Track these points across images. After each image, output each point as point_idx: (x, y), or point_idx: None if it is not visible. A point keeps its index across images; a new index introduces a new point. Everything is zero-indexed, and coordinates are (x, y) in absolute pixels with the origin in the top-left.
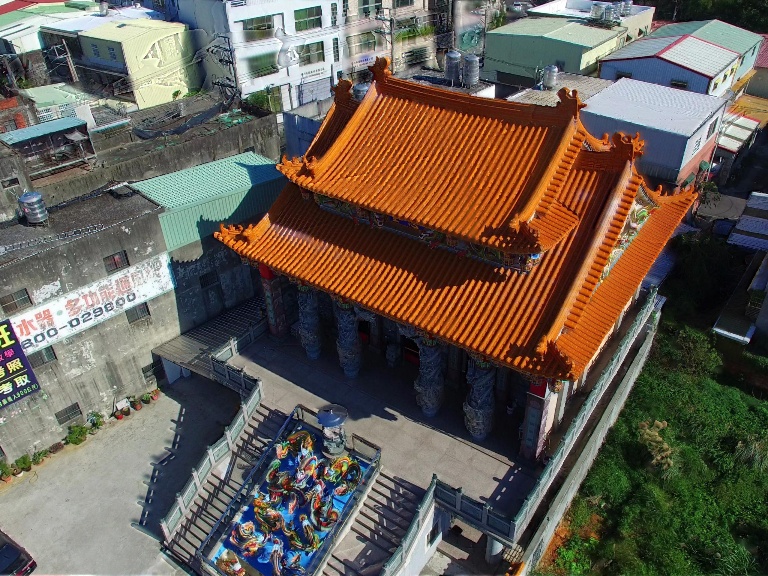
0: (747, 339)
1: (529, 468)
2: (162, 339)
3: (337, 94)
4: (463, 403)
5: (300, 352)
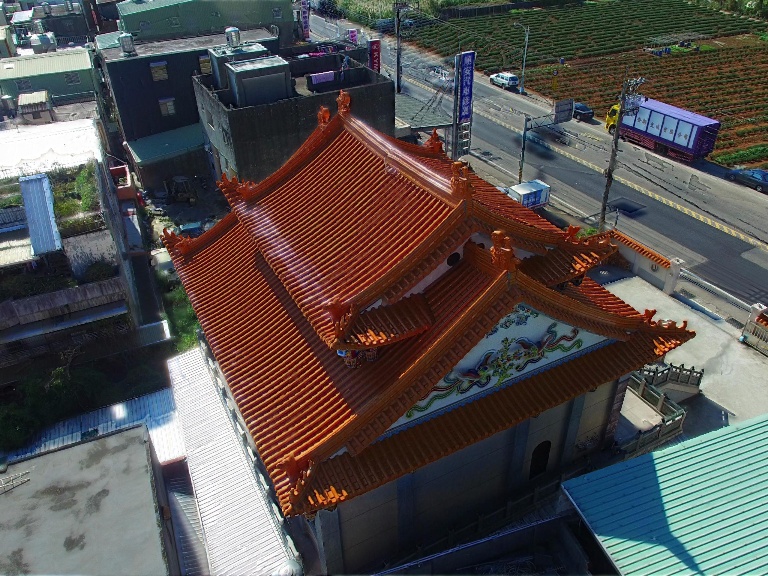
0: (165, 321)
1: None
2: None
3: None
4: None
5: None
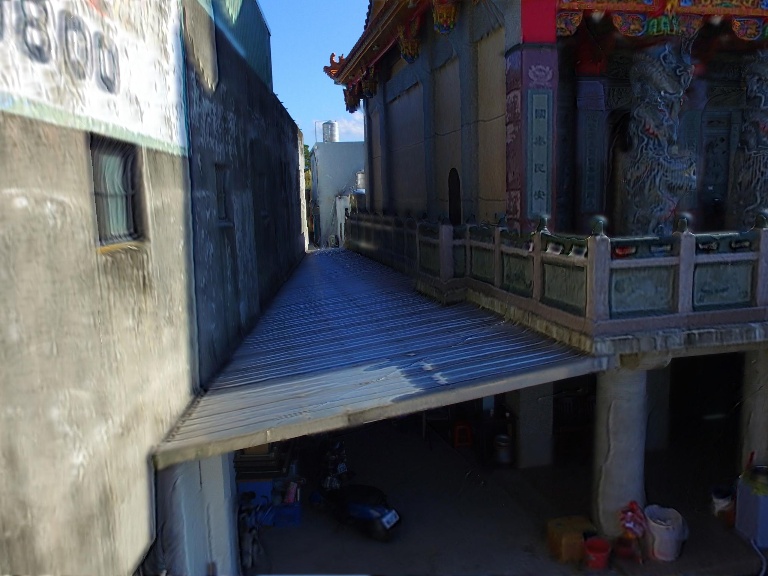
0: None
1: None
2: (168, 400)
3: None
4: None
5: None
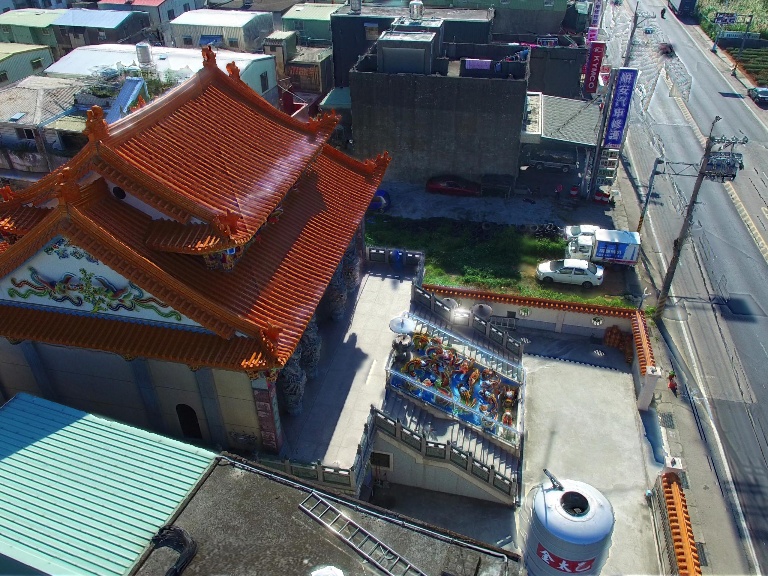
0: None
1: (368, 268)
2: None
3: (67, 197)
4: None
5: (295, 423)
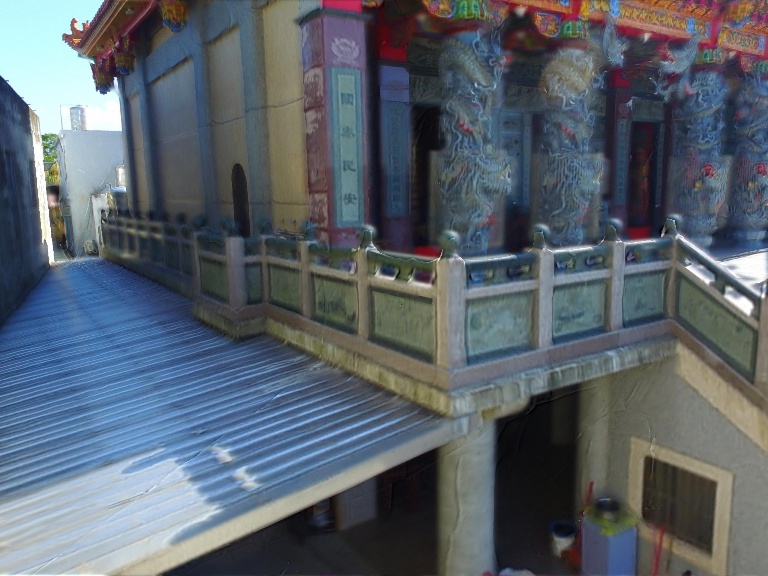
0: None
1: None
2: None
3: None
4: (762, 165)
5: None
